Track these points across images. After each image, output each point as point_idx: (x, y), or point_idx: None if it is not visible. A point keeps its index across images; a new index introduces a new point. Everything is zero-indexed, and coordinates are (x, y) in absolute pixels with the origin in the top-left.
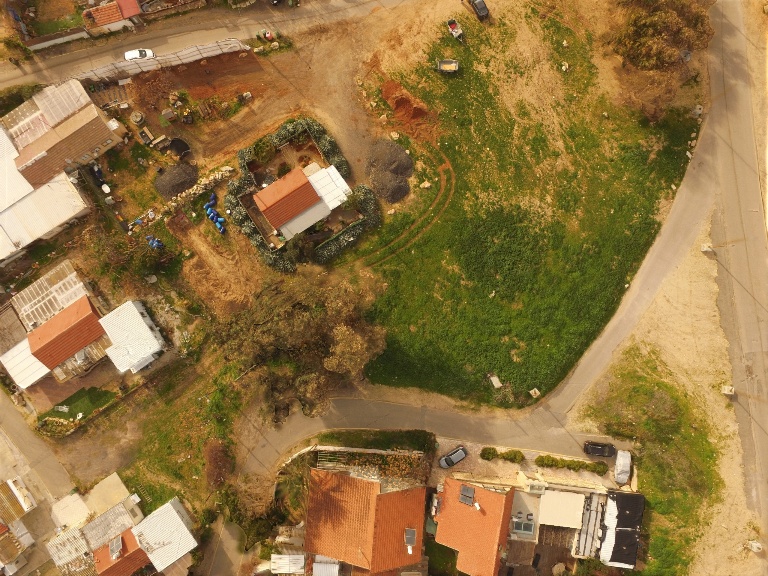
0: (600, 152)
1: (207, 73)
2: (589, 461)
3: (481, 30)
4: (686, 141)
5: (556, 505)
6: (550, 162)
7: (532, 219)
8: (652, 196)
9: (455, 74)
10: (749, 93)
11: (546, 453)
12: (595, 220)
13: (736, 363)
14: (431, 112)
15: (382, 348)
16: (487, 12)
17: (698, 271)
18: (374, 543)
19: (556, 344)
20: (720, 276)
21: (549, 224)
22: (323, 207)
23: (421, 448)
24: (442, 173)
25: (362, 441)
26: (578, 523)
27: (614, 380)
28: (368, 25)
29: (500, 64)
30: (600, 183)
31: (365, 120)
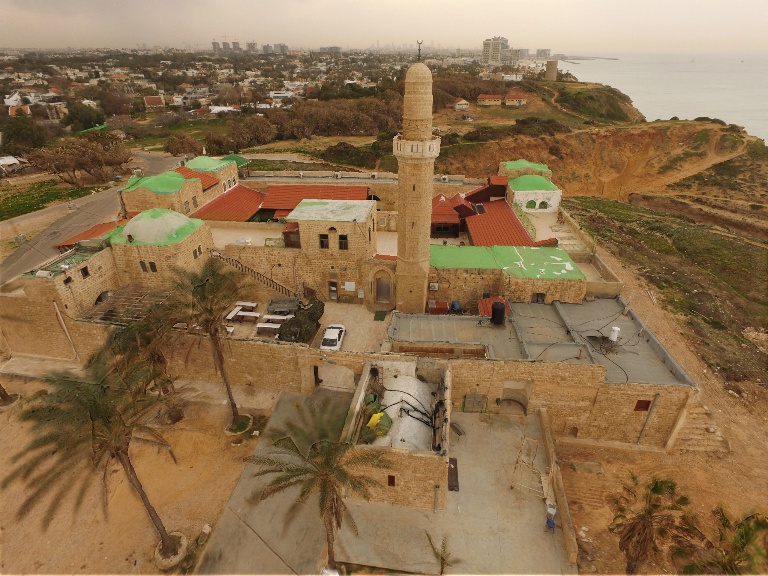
0: None
1: None
2: None
3: None
4: (94, 188)
5: None
6: None
7: None
8: (49, 200)
9: None
10: None
11: None
12: None
13: None
14: None
15: None
16: (5, 182)
17: None
18: None
19: None
20: None
21: None
22: None
23: None
24: None
25: None
26: None
27: None
28: None
29: None
30: None
31: None
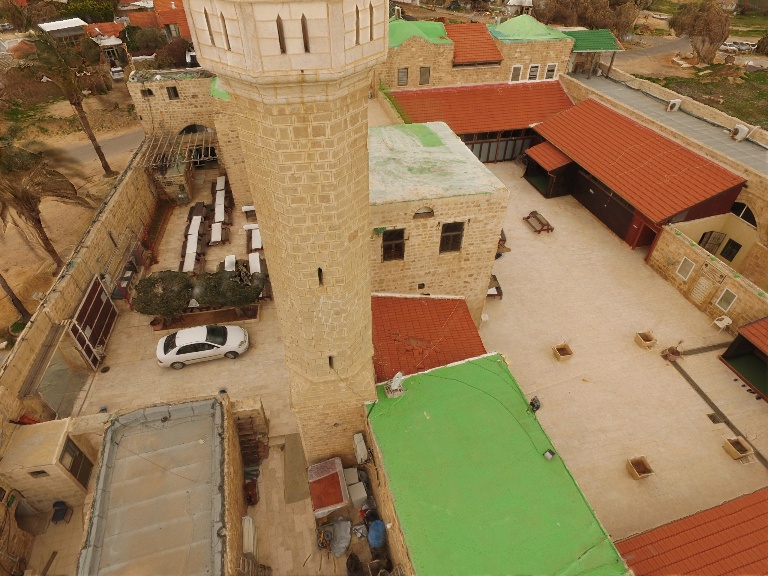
0: None
1: (397, 2)
2: None
3: None
4: None
5: None
6: None
7: None
8: None
9: None
10: (617, 61)
11: None
12: None
13: None
14: None
15: None
16: None
17: None
18: None
19: None
20: None
21: None
22: None
23: None
24: None
25: None
26: None
27: None
28: None
29: None
30: None
31: None
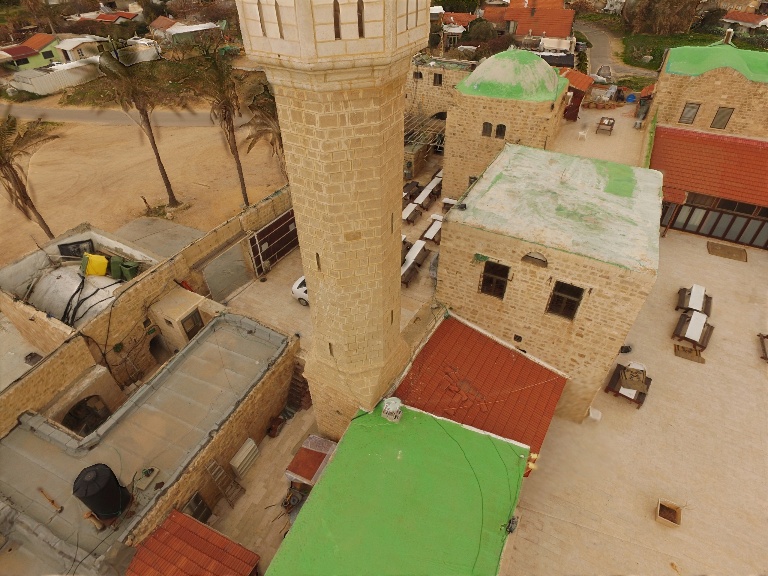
0: None
1: None
2: None
3: None
4: None
5: None
6: None
7: None
8: None
9: None
10: None
11: None
12: None
13: None
14: None
15: None
16: None
17: None
18: None
19: None
20: None
21: None
22: (751, 25)
23: None
24: None
25: None
26: None
27: None
28: None
29: None
30: None
31: None
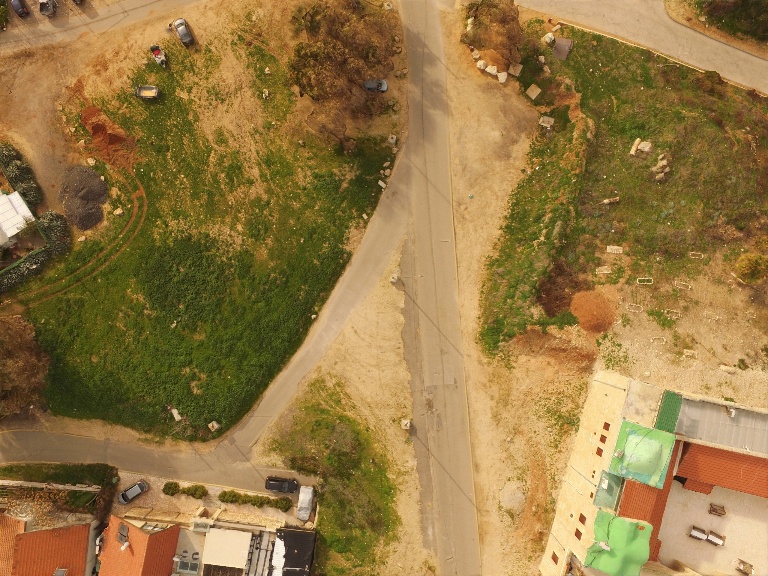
0: (294, 180)
1: None
2: (273, 497)
3: (186, 56)
4: (378, 170)
5: (220, 544)
6: (244, 190)
7: (220, 248)
8: (342, 225)
9: (157, 100)
10: (447, 123)
11: (230, 488)
12: (284, 249)
13: (417, 396)
14: (129, 138)
15: (27, 381)
16: (190, 39)
17: (386, 302)
18: None
19: (236, 376)
20: (406, 307)
21: (237, 253)
22: None
23: (100, 483)
24: (135, 200)
25: (42, 475)
26: (242, 563)
27: (298, 413)
28: (75, 50)
29: (202, 91)
30: (291, 212)
31: (63, 145)
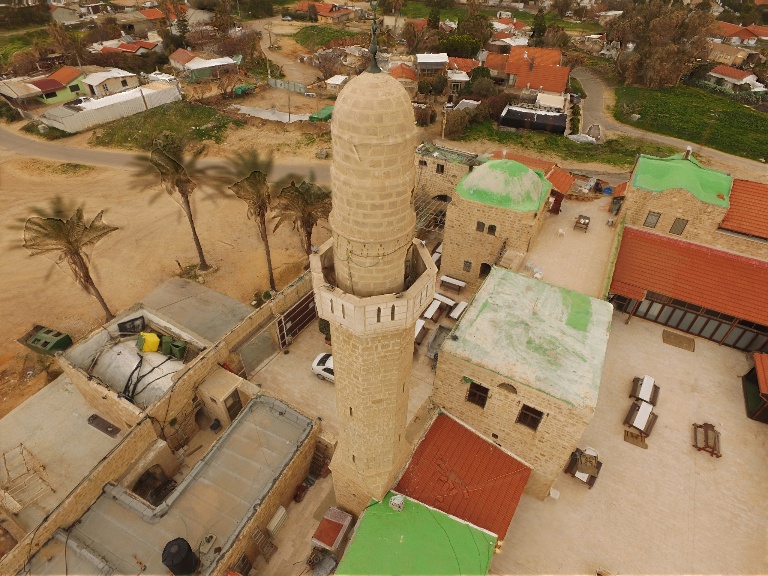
0: None
1: None
2: None
3: None
4: None
5: None
6: None
7: None
8: None
9: None
10: None
11: None
12: None
13: None
14: None
15: (660, 57)
16: None
17: None
18: (531, 48)
19: None
20: None
21: None
22: (736, 81)
23: None
24: None
25: None
26: None
27: None
28: None
29: None
30: None
31: None
